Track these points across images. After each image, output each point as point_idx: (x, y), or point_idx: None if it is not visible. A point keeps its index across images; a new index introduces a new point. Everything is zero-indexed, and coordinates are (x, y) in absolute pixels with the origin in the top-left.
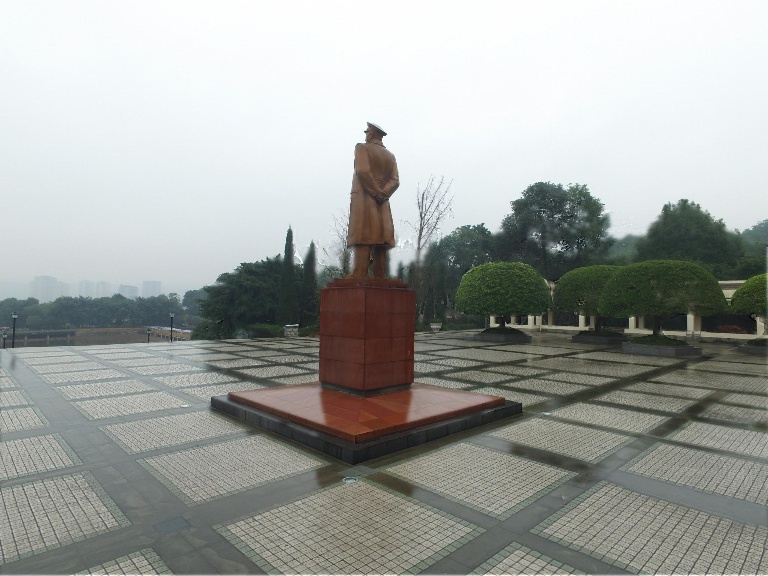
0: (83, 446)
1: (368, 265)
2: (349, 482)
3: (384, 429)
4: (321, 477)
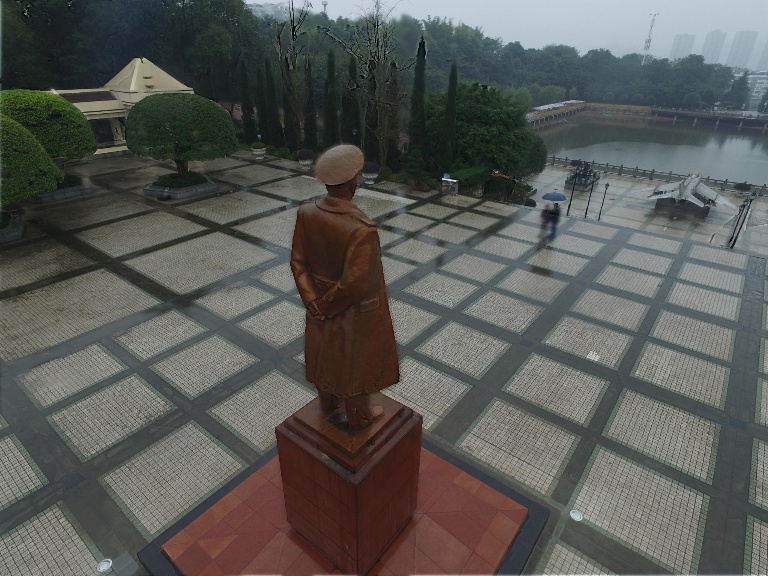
0: (227, 384)
1: (325, 396)
2: (98, 565)
3: (181, 572)
4: (120, 541)
